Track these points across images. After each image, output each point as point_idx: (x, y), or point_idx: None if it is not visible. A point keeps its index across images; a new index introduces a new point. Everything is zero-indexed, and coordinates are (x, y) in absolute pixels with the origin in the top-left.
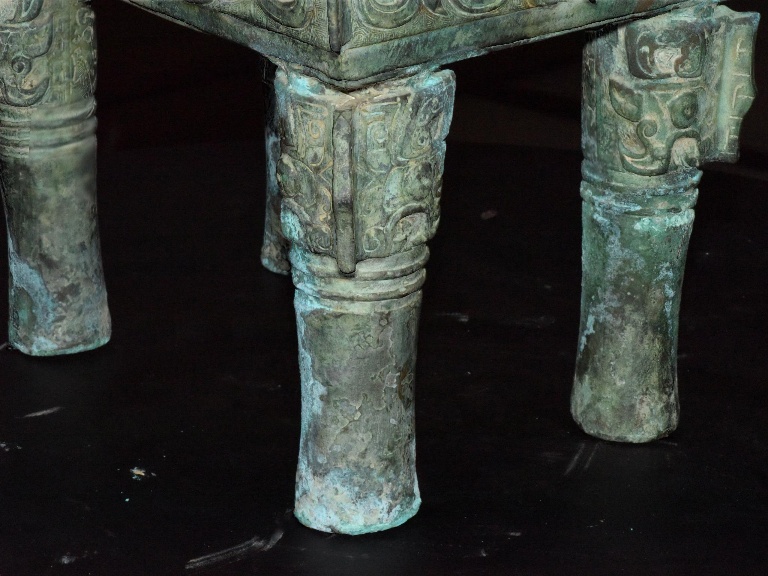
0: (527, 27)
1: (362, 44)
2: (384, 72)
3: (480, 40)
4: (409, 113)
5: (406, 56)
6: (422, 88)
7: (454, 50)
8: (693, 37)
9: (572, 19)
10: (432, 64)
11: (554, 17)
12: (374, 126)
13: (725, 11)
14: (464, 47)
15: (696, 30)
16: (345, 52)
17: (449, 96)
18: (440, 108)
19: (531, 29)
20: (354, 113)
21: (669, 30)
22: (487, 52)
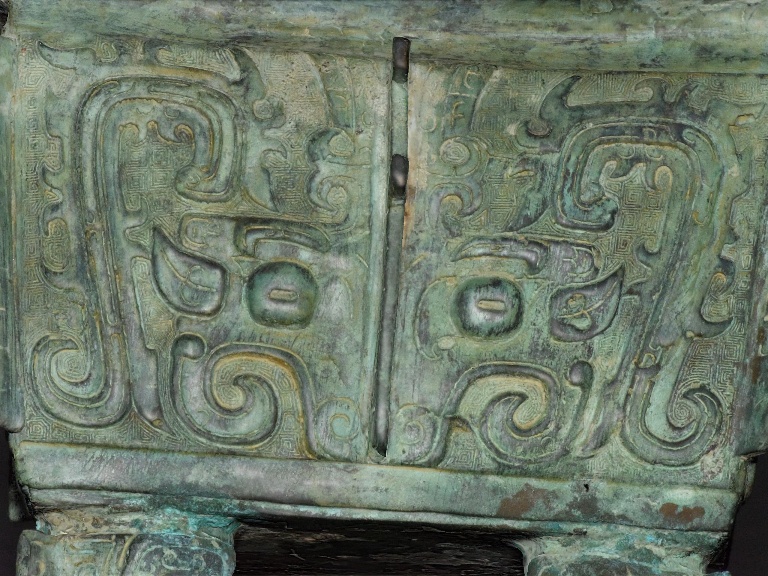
0: (311, 487)
1: (42, 439)
2: (81, 488)
3: (234, 486)
4: (126, 557)
5: (114, 475)
6: (153, 533)
7: (192, 488)
8: (605, 575)
9: (387, 496)
10: (166, 504)
11: (355, 485)
12: (83, 568)
13: (689, 571)
14: (209, 488)
15: (611, 566)
16: (21, 446)
17: (211, 567)
18: (185, 570)
19: (318, 492)
20: (56, 545)
21: (575, 564)
22: (256, 512)
